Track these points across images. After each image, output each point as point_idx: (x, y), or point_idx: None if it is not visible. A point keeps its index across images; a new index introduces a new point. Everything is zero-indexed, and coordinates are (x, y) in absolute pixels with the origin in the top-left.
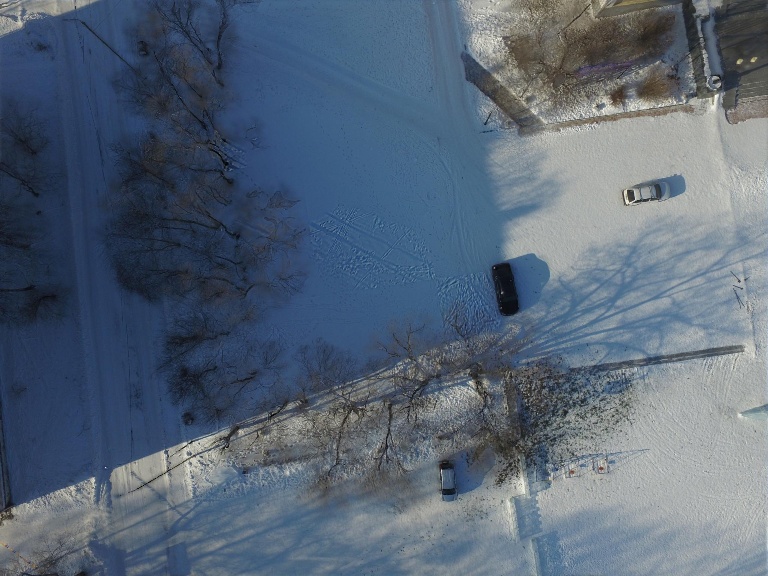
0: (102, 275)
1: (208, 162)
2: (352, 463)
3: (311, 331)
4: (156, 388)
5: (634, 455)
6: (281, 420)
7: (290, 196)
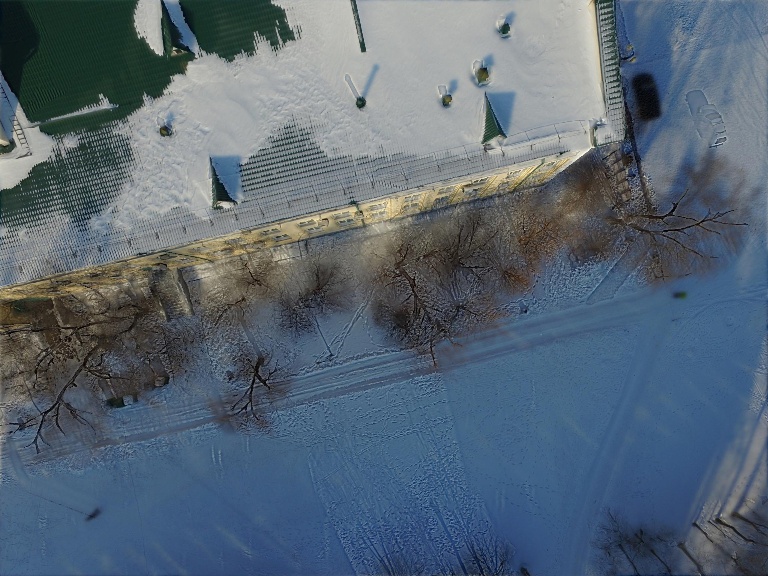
0: None
1: None
2: None
3: None
4: None
5: None
6: None
7: (744, 456)
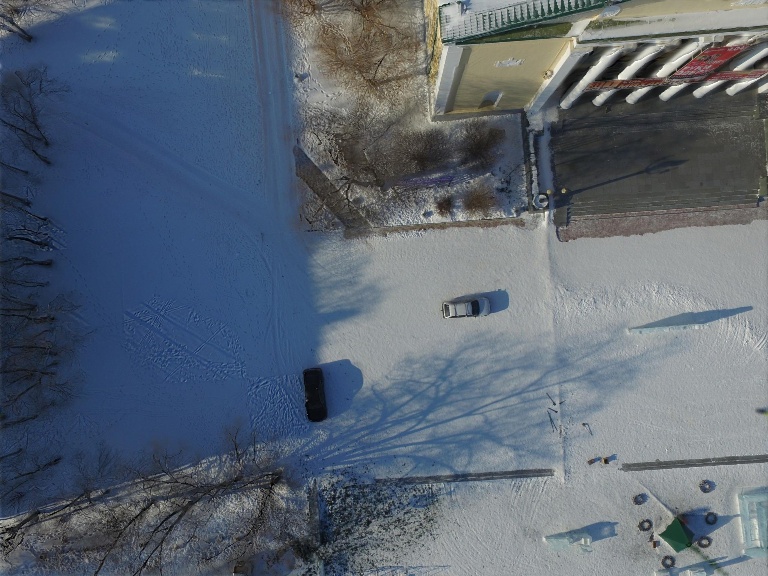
0: None
1: (4, 253)
2: (151, 556)
3: (117, 421)
4: None
5: (435, 570)
6: (82, 508)
7: (107, 282)
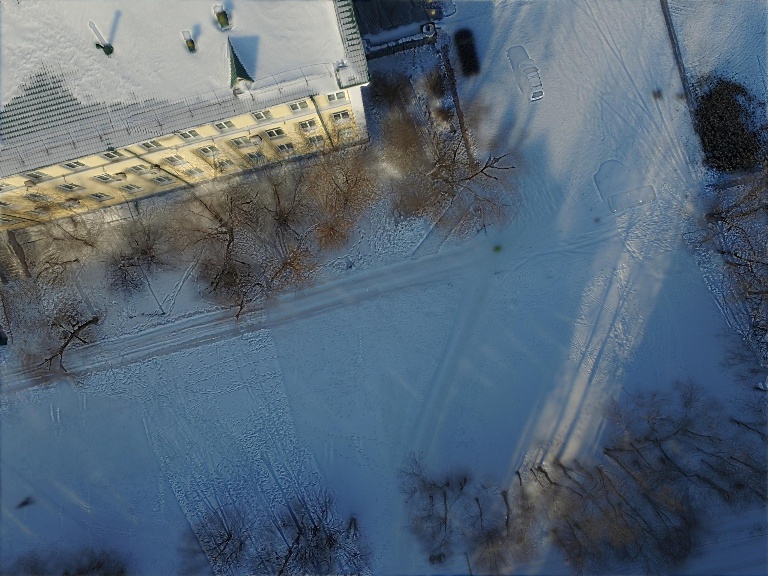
0: (674, 573)
1: (570, 485)
2: None
3: (689, 373)
4: (755, 512)
5: (764, 69)
6: None
7: (565, 405)
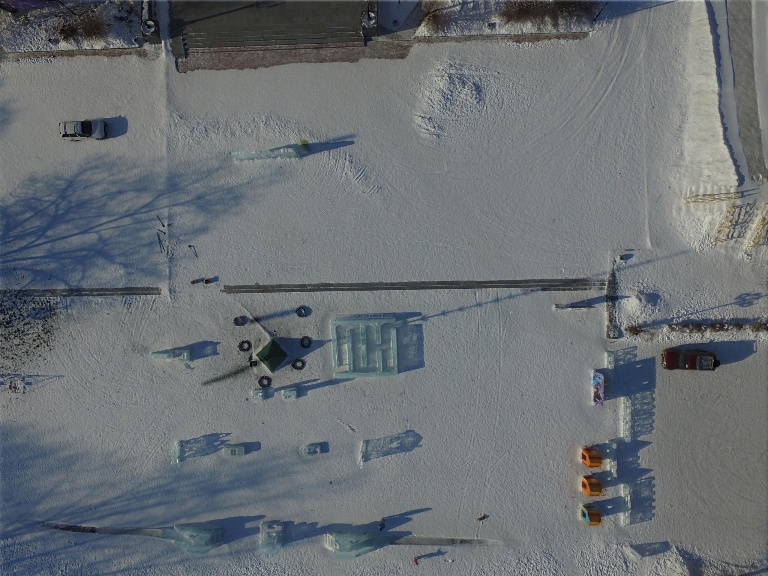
0: None
1: None
2: None
3: None
4: None
5: (50, 380)
6: None
7: None
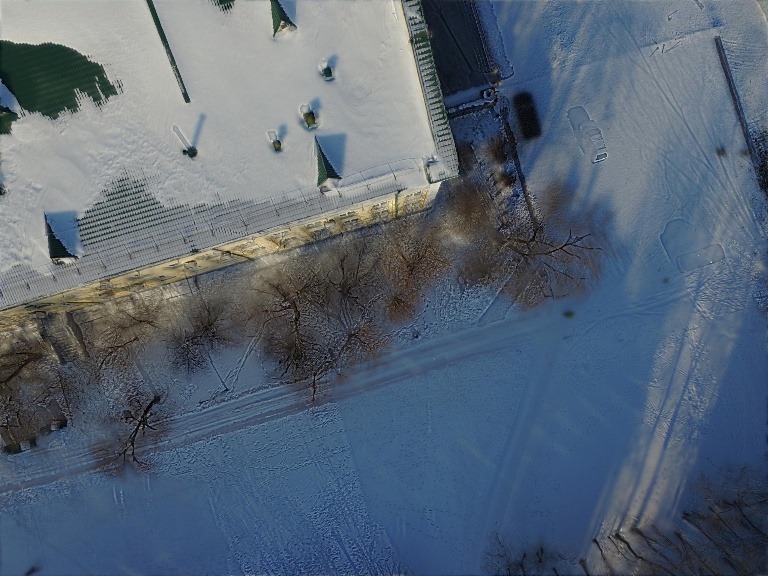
0: None
1: (657, 559)
2: None
3: (766, 433)
4: None
5: None
6: None
7: (641, 470)
